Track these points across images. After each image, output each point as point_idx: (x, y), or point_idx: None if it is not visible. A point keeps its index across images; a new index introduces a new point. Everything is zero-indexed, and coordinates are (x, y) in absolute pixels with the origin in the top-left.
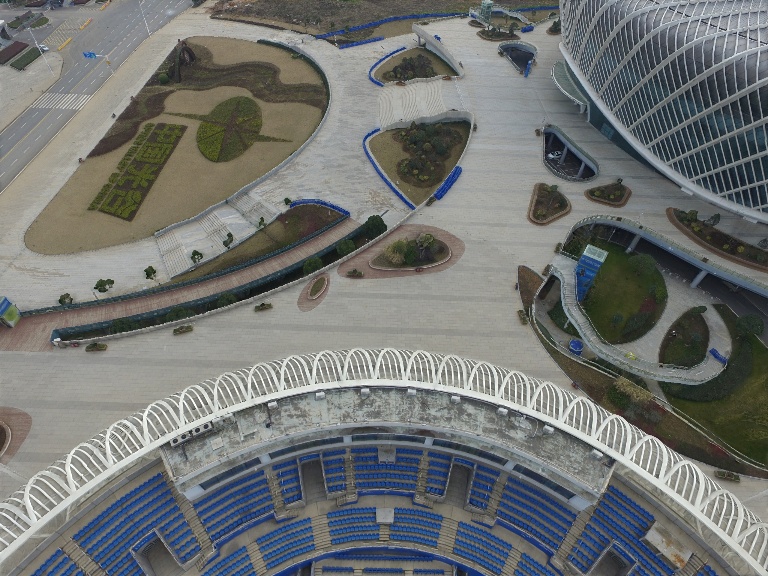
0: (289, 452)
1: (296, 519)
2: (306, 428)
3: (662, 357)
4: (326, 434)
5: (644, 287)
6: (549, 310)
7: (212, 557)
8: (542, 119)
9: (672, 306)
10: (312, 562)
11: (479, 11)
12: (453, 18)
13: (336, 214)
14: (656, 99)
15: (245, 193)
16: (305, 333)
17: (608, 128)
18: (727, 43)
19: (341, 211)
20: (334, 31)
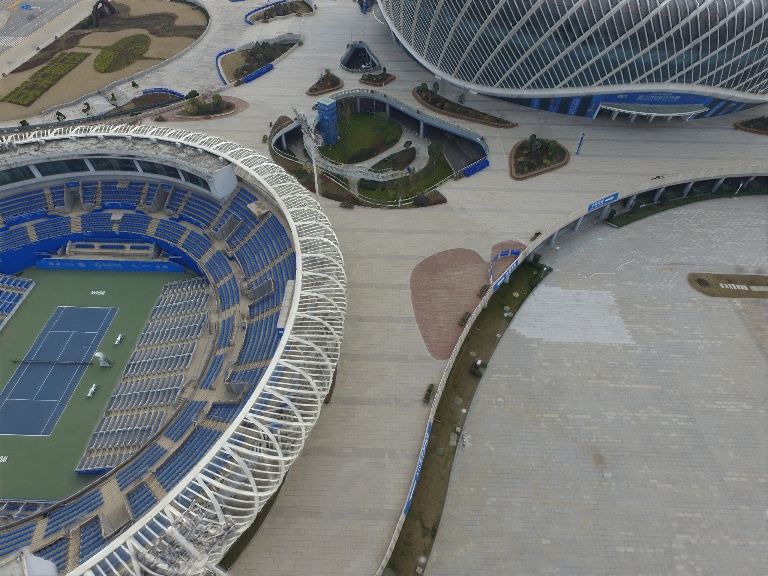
0: (55, 174)
1: (61, 217)
2: (58, 152)
3: (369, 170)
4: (70, 156)
5: (382, 136)
6: None
7: (3, 227)
8: (358, 39)
9: (397, 147)
10: (69, 240)
11: None
12: None
13: None
14: (399, 4)
15: (114, 87)
16: None
17: None
18: None
19: (179, 96)
20: None
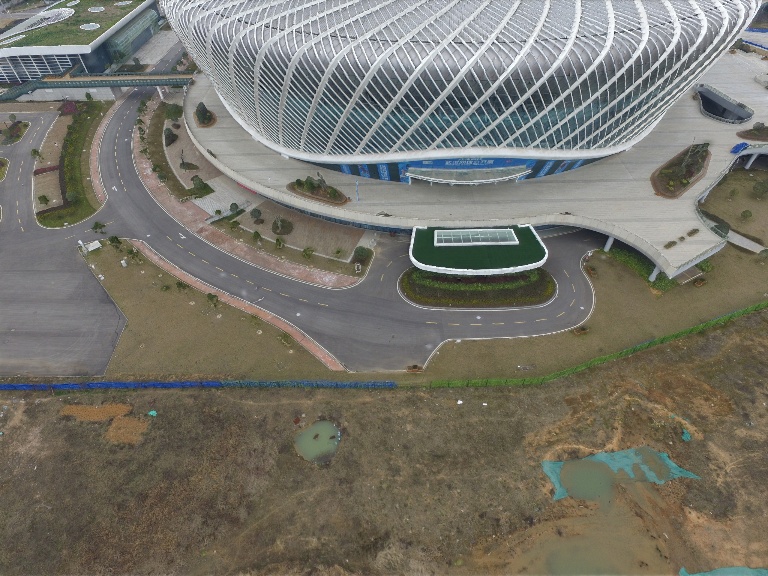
0: None
1: None
2: None
3: None
4: None
5: None
6: None
7: None
8: None
9: None
10: None
11: None
12: None
13: None
14: None
15: None
16: None
17: None
18: None
19: None
20: None
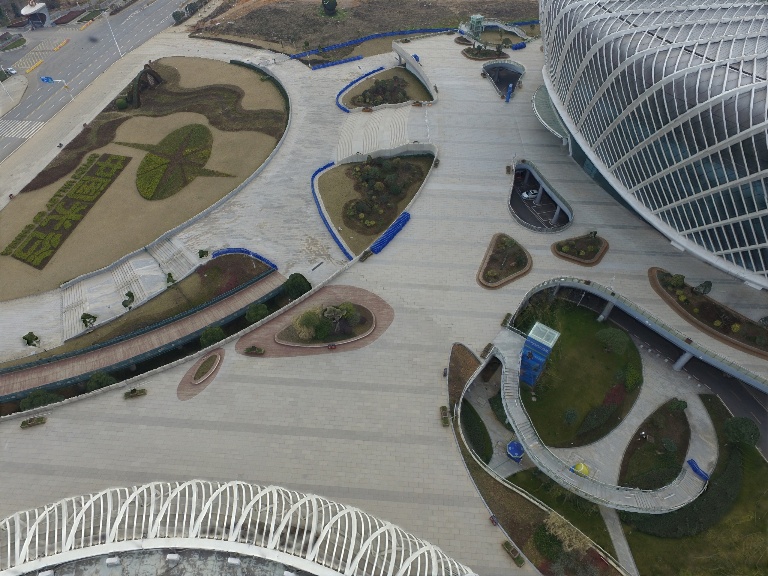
0: None
1: None
2: None
3: (624, 469)
4: None
5: (613, 369)
6: (491, 397)
7: None
8: (517, 153)
9: (647, 395)
10: None
11: (468, 26)
12: (439, 35)
13: (262, 266)
14: (636, 139)
15: (168, 239)
16: (175, 430)
17: (590, 165)
18: (714, 77)
19: (268, 263)
20: (311, 50)
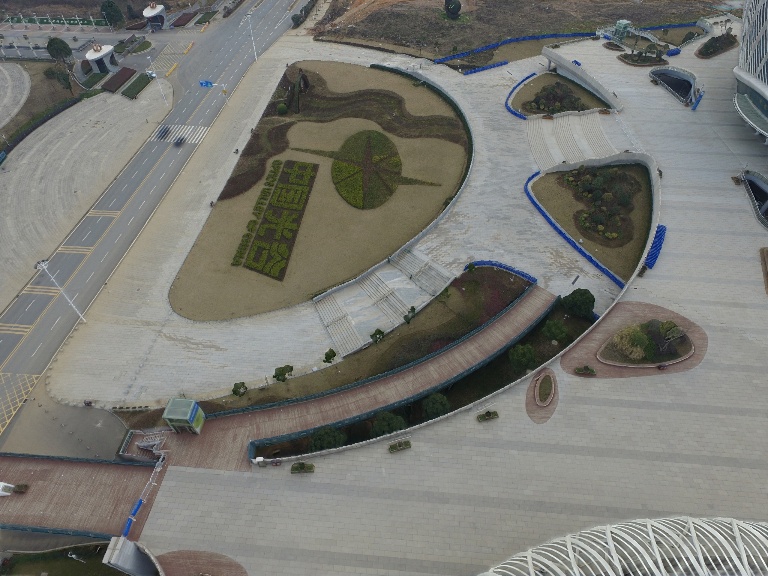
0: None
1: None
2: None
3: None
4: None
5: None
6: None
7: None
8: (734, 163)
9: None
10: None
11: (612, 32)
12: (585, 40)
13: (519, 280)
14: None
15: (407, 250)
16: (550, 456)
17: None
18: None
19: (525, 276)
20: (452, 54)
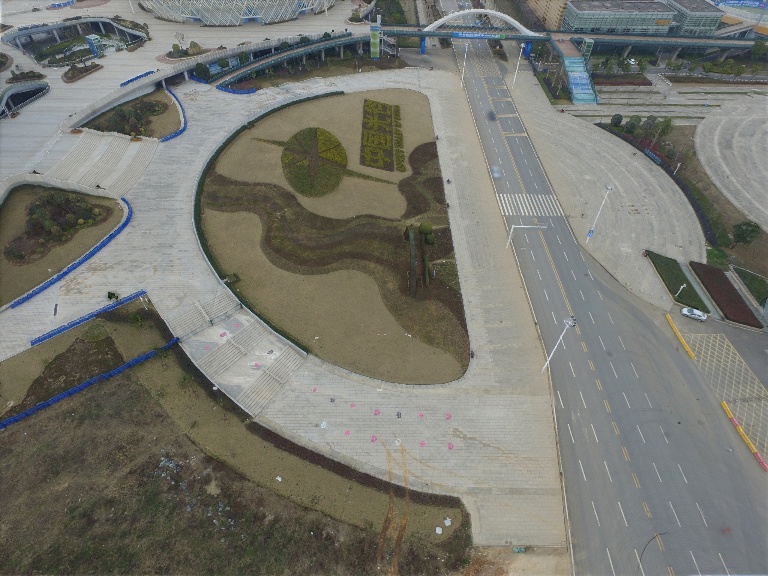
0: None
1: None
2: None
3: None
4: None
5: None
6: None
7: None
8: None
9: None
10: None
11: None
12: None
13: None
14: None
15: None
16: None
17: None
18: None
19: None
20: None
